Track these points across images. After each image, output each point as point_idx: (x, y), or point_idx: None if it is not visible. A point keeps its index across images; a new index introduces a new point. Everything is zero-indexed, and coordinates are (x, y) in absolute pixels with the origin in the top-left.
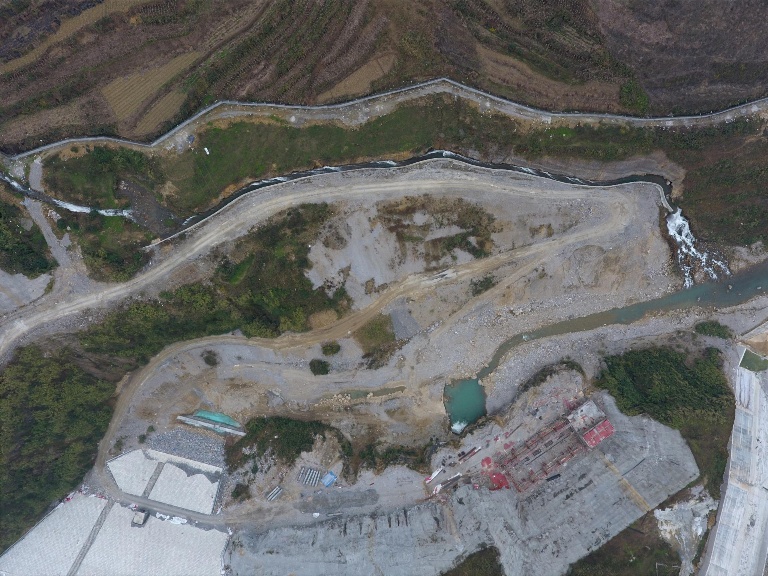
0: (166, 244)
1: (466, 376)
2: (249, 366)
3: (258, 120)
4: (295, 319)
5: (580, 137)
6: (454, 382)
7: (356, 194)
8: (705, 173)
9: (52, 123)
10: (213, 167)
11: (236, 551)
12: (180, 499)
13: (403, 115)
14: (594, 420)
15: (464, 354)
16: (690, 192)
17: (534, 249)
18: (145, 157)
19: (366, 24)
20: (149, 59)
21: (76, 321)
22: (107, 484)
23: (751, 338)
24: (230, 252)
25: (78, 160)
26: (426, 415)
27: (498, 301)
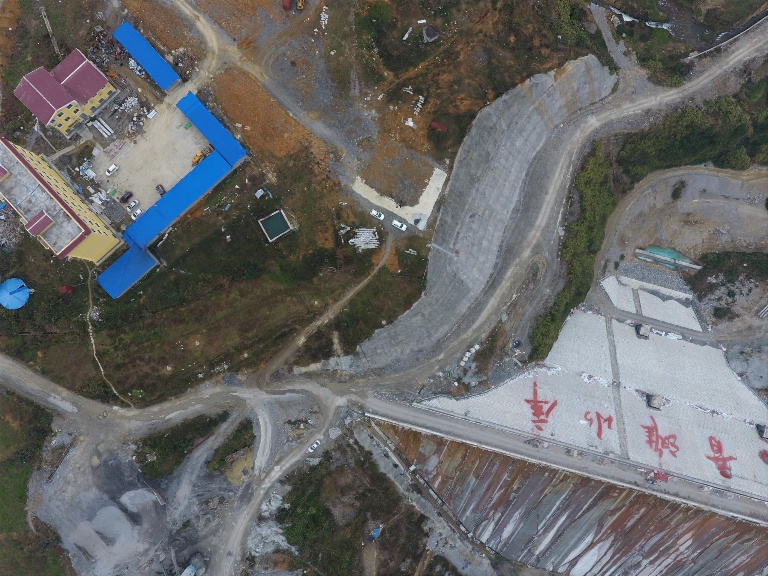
0: (704, 56)
1: None
2: (707, 201)
3: None
4: None
5: None
6: None
7: None
8: None
9: None
10: None
11: (754, 357)
12: (670, 318)
13: None
14: None
15: None
16: None
17: None
18: None
19: None
20: None
21: (640, 120)
22: (602, 302)
23: None
24: (756, 69)
25: None
26: None
27: None
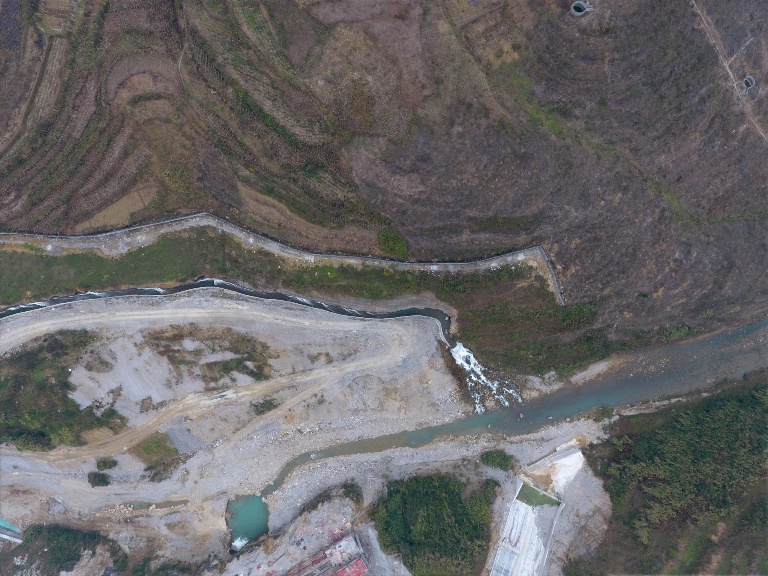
0: None
1: (250, 493)
2: (28, 474)
3: (10, 248)
4: (63, 437)
5: (345, 276)
6: (238, 498)
7: (119, 321)
8: (477, 314)
9: None
10: None
11: None
12: None
13: (166, 246)
14: (352, 556)
15: (249, 471)
16: (465, 330)
17: (314, 374)
18: None
19: (127, 156)
20: None
21: None
22: None
23: (534, 471)
24: None
25: None
26: (207, 530)
27: (282, 421)
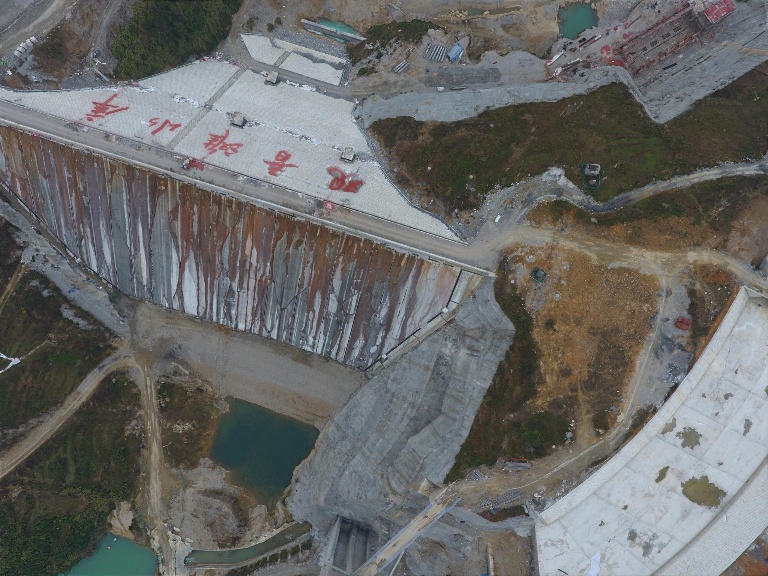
0: None
1: None
2: None
3: None
4: None
5: None
6: (568, 5)
7: None
8: None
9: None
10: None
11: (369, 99)
12: (309, 73)
13: None
14: None
15: None
16: None
17: None
18: None
19: None
20: None
21: None
22: (240, 53)
23: None
24: None
25: None
26: (540, 32)
27: None
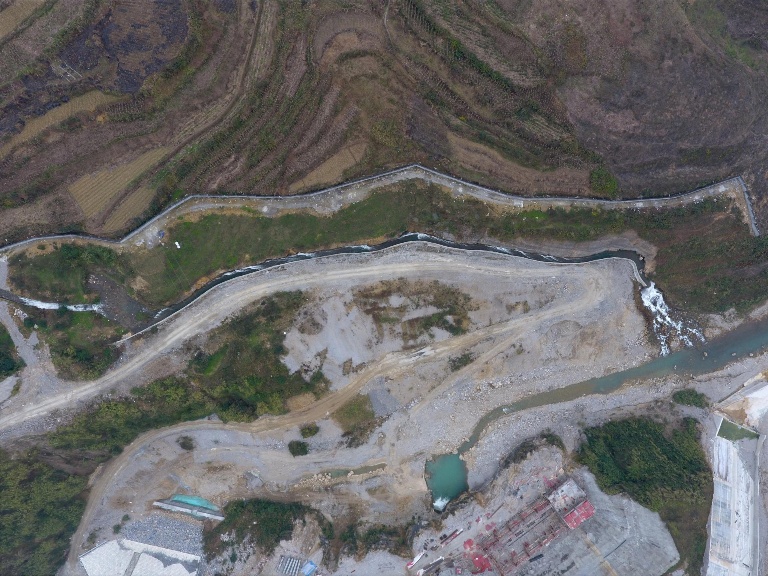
0: (137, 338)
1: (447, 451)
2: (226, 449)
3: (230, 212)
4: (272, 404)
5: (552, 220)
6: (435, 458)
7: (331, 280)
8: (676, 250)
9: (17, 222)
10: (184, 260)
11: None
12: None
13: (376, 201)
14: (575, 500)
15: (444, 429)
16: (662, 268)
17: (511, 325)
18: (114, 254)
19: (337, 113)
20: (117, 156)
21: (44, 423)
22: None
23: (727, 406)
24: (203, 344)
25: (45, 257)
26: (408, 493)
27: (477, 376)
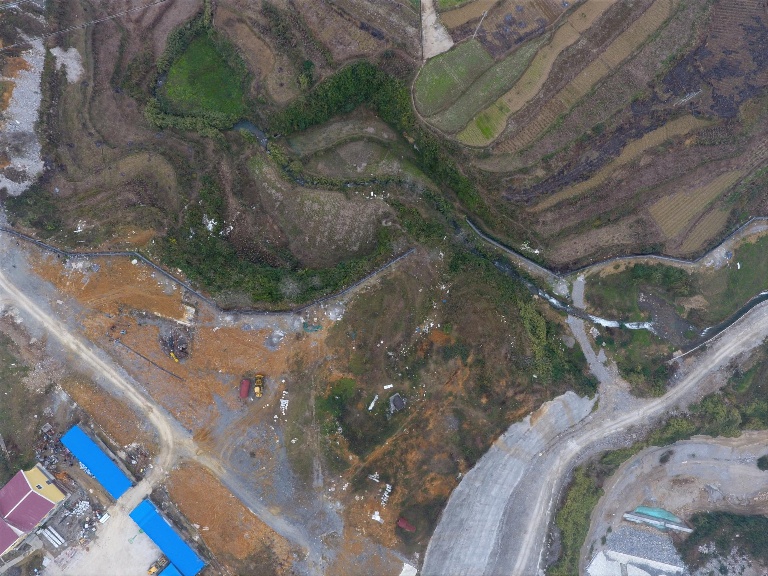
0: (689, 356)
1: None
2: (697, 462)
3: None
4: None
5: None
6: None
7: None
8: None
9: (602, 242)
10: (741, 281)
11: None
12: None
13: None
14: None
15: None
16: None
17: None
18: (687, 274)
19: None
20: (696, 178)
21: (622, 439)
22: None
23: None
24: (743, 362)
25: (616, 276)
26: None
27: None
